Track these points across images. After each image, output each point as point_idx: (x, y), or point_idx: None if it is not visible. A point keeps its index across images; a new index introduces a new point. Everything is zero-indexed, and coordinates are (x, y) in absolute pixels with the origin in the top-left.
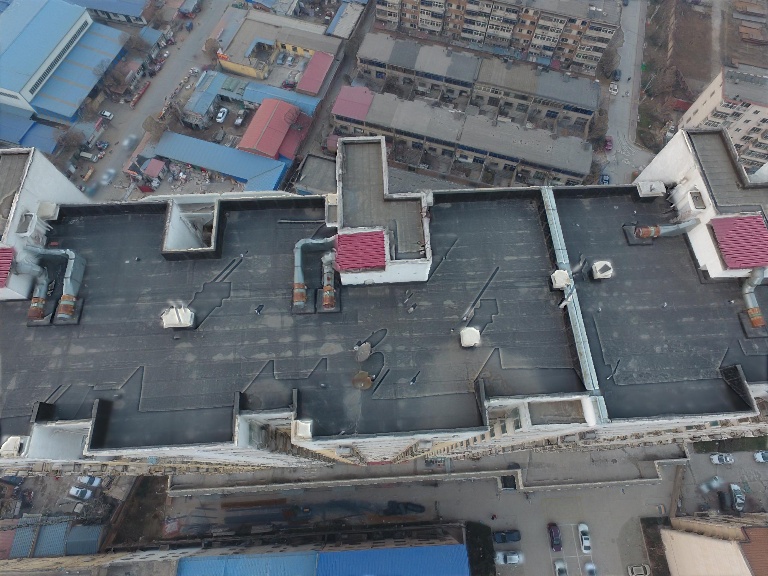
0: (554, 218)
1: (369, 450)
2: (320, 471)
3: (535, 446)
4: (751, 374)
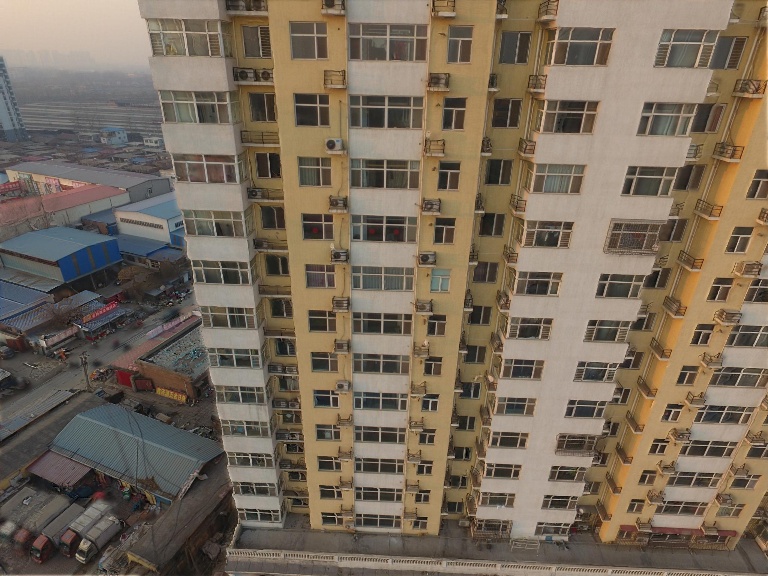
0: None
1: None
2: (543, 553)
3: None
4: None
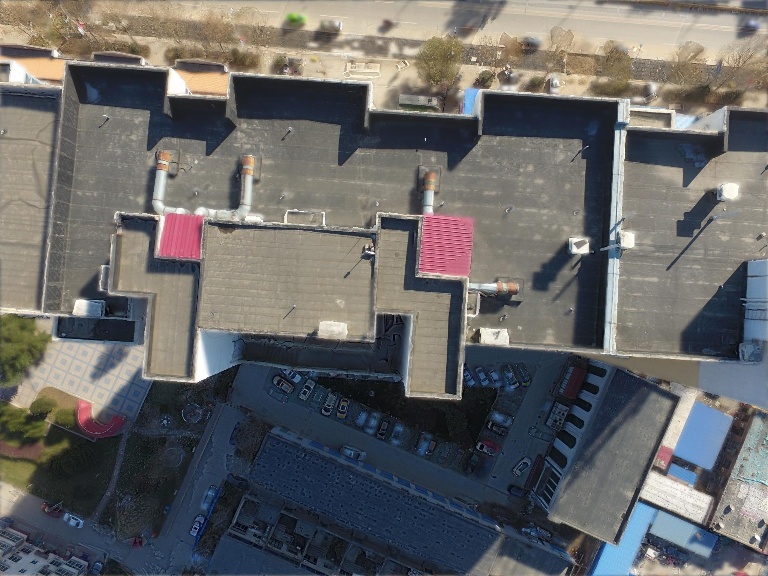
0: (612, 312)
1: None
2: None
3: None
4: (449, 135)
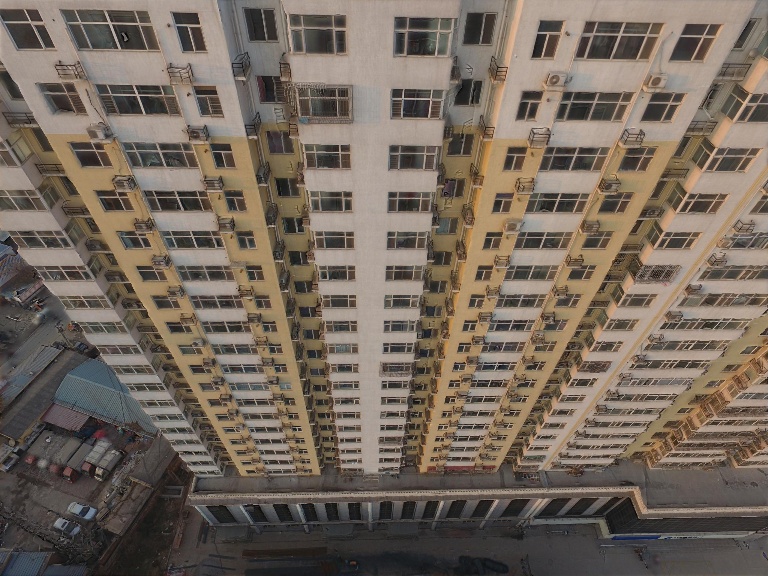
0: None
1: (533, 224)
2: (383, 481)
3: (743, 224)
4: None
